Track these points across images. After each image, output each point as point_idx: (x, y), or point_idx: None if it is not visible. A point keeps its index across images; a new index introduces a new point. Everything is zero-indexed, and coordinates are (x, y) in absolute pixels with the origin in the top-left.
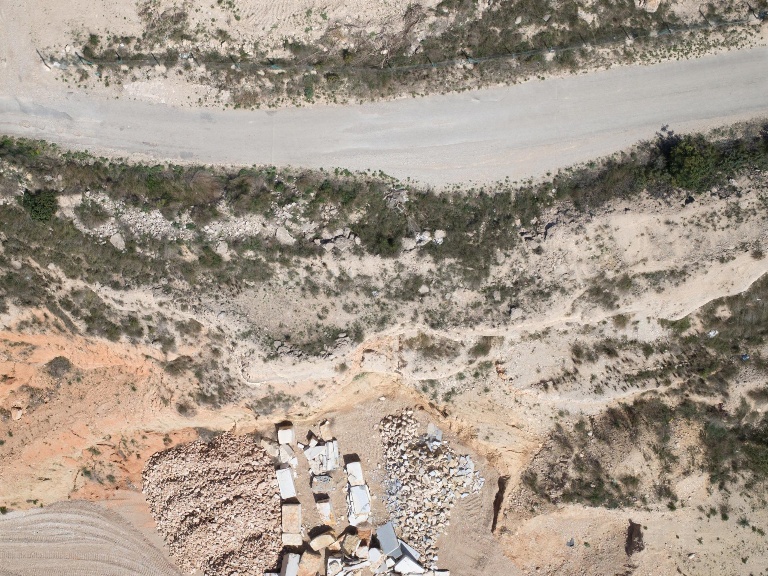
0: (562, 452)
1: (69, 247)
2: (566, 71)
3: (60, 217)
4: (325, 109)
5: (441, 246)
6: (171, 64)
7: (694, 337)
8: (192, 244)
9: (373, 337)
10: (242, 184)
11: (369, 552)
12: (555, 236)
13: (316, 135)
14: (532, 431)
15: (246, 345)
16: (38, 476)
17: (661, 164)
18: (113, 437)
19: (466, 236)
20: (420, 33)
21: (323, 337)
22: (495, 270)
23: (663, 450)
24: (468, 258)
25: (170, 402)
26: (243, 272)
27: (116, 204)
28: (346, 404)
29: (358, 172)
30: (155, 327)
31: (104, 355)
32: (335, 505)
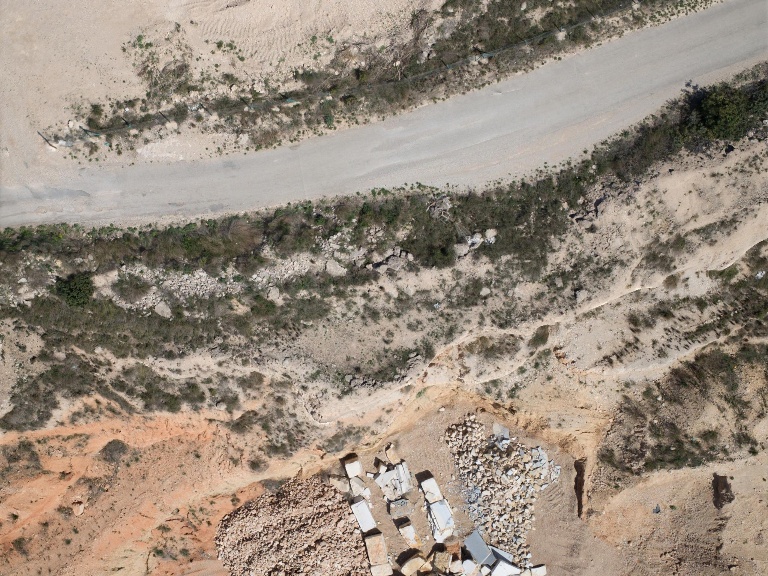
0: (635, 422)
1: (113, 326)
2: (580, 47)
3: (97, 298)
4: (348, 132)
5: (495, 245)
6: (182, 119)
7: (743, 282)
8: (242, 296)
9: (443, 350)
10: (281, 225)
11: (463, 565)
12: (607, 211)
13: (345, 160)
14: (600, 408)
15: (317, 386)
16: (111, 567)
17: (695, 119)
18: (181, 510)
19: (517, 230)
20: (430, 38)
21: (393, 361)
22: (552, 257)
23: (734, 398)
24: (524, 251)
25: (240, 461)
26: (299, 313)
27: (155, 272)
28: (408, 423)
29: (395, 189)
30: (216, 388)
31: (163, 429)
32: (417, 526)
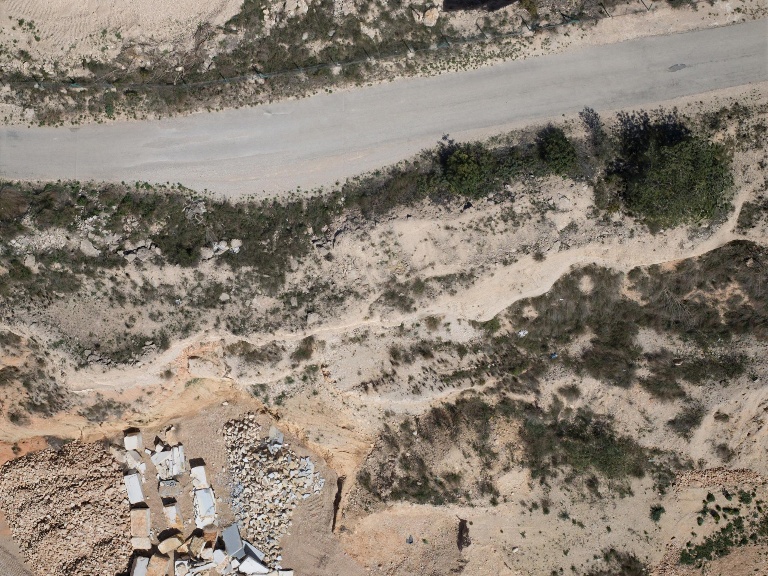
0: (390, 452)
1: None
2: (352, 84)
3: None
4: (126, 125)
5: (237, 255)
6: None
7: (505, 337)
8: (1, 258)
9: (180, 344)
10: (47, 199)
11: (214, 554)
12: (342, 243)
13: (117, 150)
14: (363, 432)
15: (58, 354)
16: None
17: (440, 172)
18: None
19: (261, 245)
20: (211, 50)
21: (131, 345)
22: (290, 277)
23: (483, 447)
24: (263, 266)
25: (2, 411)
26: (52, 284)
27: None
28: (189, 410)
29: (158, 185)
30: None
31: None
32: (183, 509)
